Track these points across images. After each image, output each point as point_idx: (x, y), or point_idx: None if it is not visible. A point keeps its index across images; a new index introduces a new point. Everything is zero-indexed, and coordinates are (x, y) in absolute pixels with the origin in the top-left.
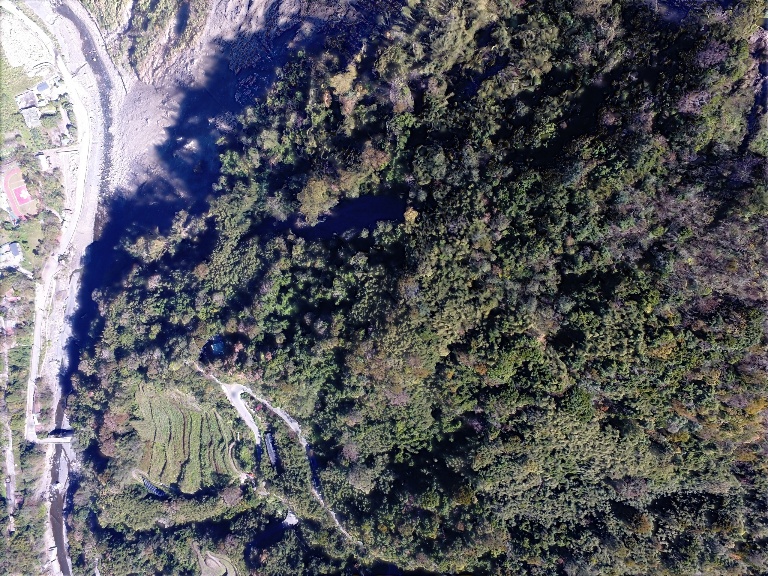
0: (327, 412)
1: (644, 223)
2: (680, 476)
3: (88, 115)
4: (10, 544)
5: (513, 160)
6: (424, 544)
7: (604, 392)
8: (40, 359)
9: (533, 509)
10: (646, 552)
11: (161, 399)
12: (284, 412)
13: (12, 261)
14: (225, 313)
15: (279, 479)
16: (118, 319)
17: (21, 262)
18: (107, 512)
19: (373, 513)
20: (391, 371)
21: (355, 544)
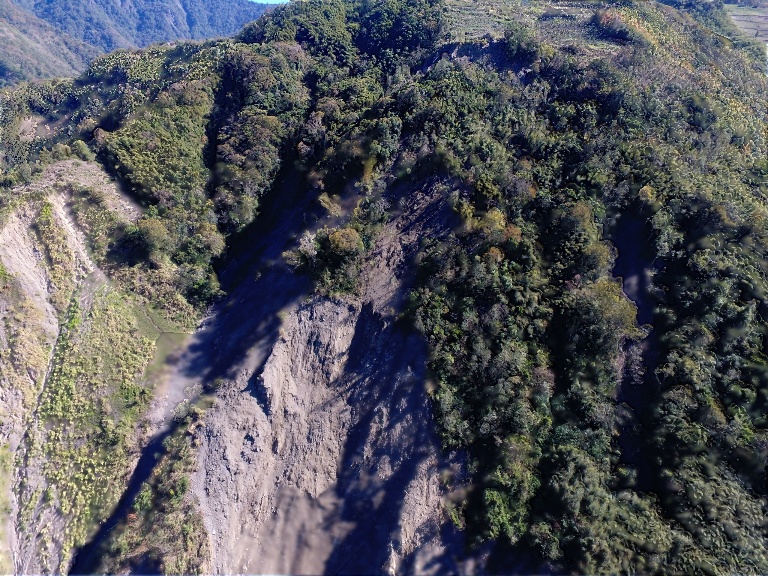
0: None
1: None
2: None
3: None
4: None
5: None
6: None
7: None
8: None
9: None
10: None
11: None
12: None
13: None
14: None
15: None
16: None
17: None
18: None
19: None
20: None
21: None
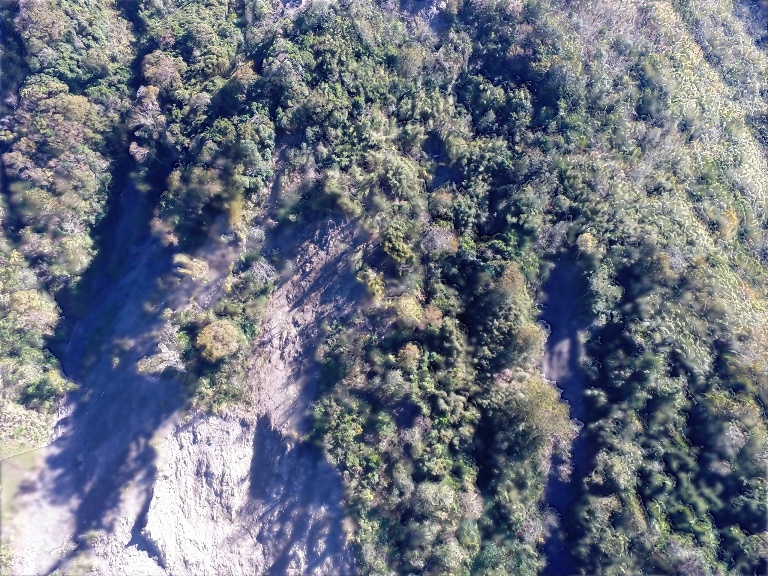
0: None
1: (607, 37)
2: None
3: None
4: None
5: (541, 125)
6: None
7: (724, 124)
8: None
9: None
10: None
11: None
12: None
13: None
14: None
15: None
16: None
17: None
18: None
19: None
20: None
21: None
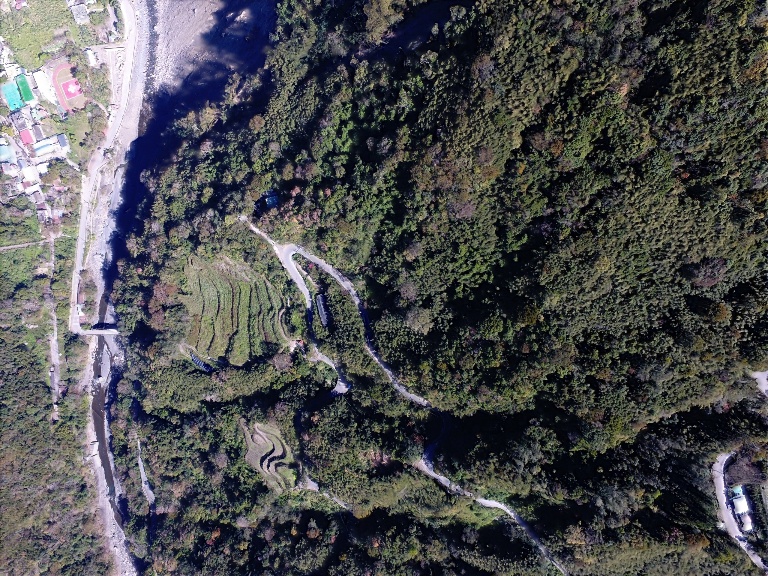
0: (384, 255)
1: None
2: (760, 255)
3: (134, 13)
4: (54, 431)
5: None
6: (486, 376)
7: (688, 147)
8: (85, 251)
9: (602, 320)
10: (724, 343)
11: (210, 271)
12: (336, 271)
13: (59, 152)
14: (280, 164)
15: (331, 338)
16: (168, 190)
17: (68, 154)
18: (153, 390)
19: (431, 354)
20: (460, 173)
21: (409, 400)
